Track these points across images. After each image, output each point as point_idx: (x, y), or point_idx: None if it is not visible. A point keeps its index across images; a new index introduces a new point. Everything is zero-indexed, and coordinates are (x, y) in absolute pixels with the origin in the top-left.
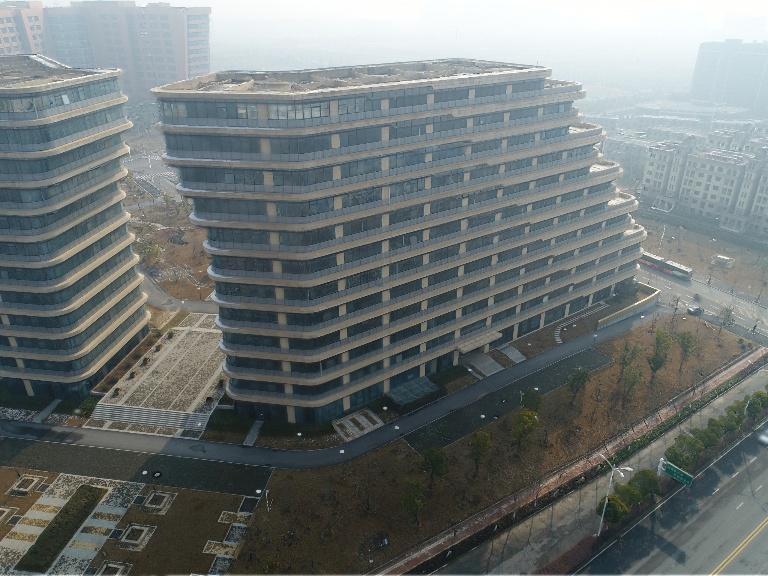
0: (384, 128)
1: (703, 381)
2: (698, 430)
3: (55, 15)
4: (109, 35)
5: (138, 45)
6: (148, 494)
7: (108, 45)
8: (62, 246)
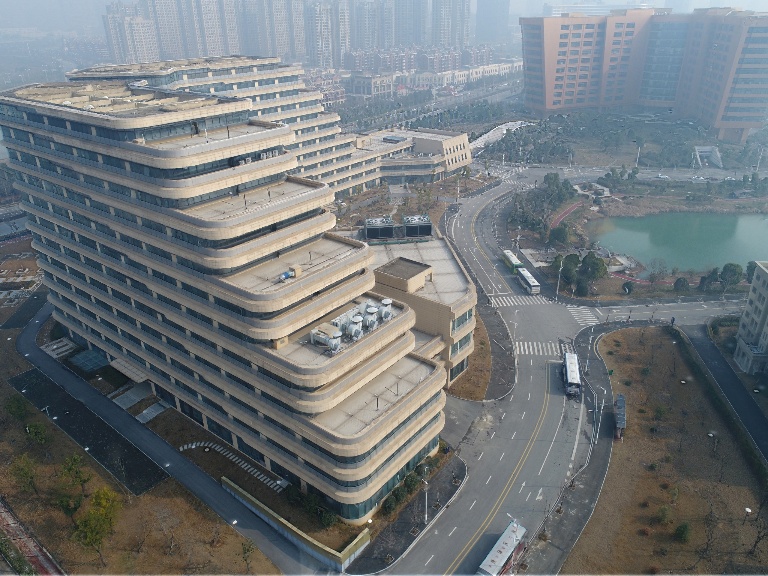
0: (29, 134)
1: None
2: None
3: (659, 22)
4: (694, 45)
5: (709, 58)
6: (20, 299)
7: (691, 55)
8: None
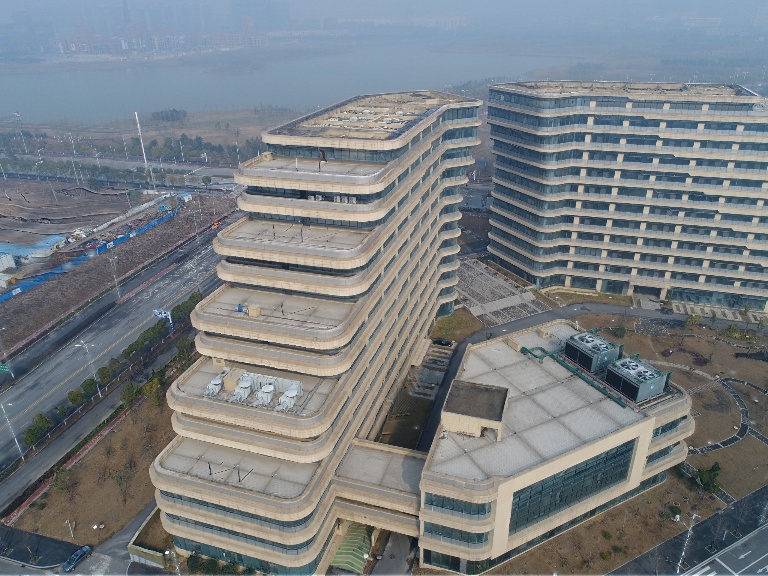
0: None
1: (114, 427)
2: (141, 342)
3: None
4: None
5: None
6: None
7: None
8: (500, 176)
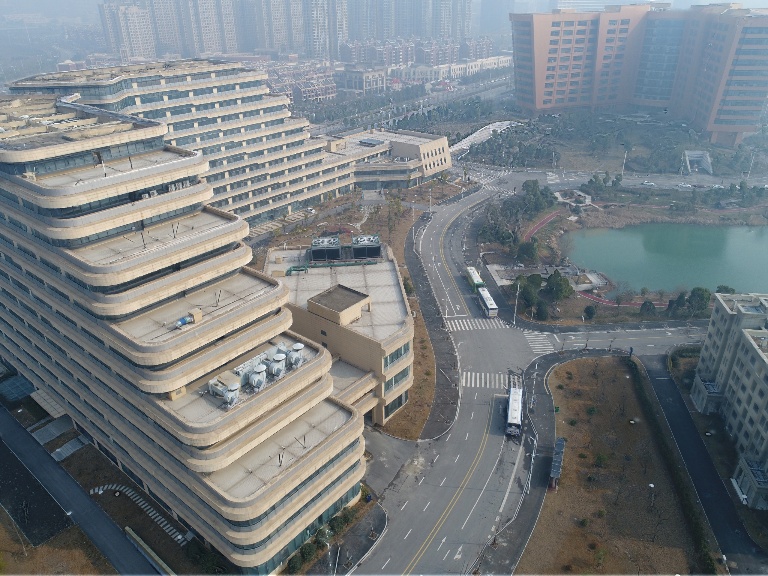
0: None
1: None
2: None
3: (655, 18)
4: (689, 43)
5: (704, 57)
6: None
7: (686, 54)
8: None
